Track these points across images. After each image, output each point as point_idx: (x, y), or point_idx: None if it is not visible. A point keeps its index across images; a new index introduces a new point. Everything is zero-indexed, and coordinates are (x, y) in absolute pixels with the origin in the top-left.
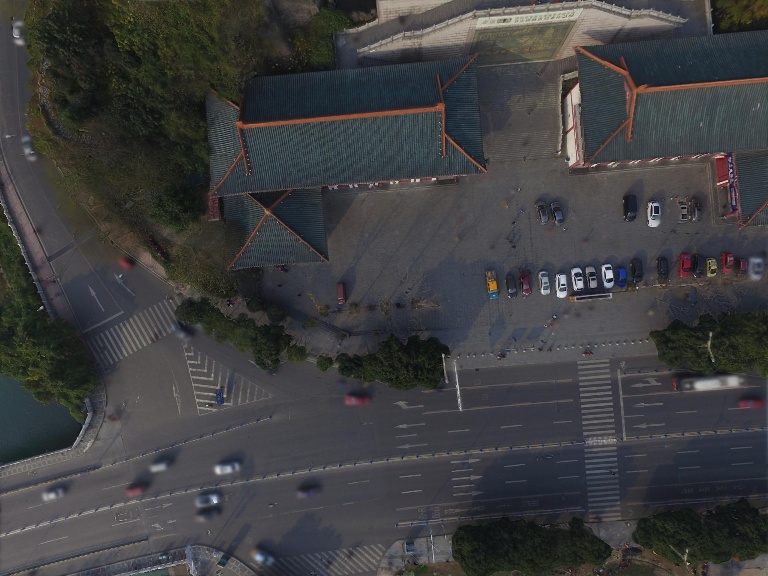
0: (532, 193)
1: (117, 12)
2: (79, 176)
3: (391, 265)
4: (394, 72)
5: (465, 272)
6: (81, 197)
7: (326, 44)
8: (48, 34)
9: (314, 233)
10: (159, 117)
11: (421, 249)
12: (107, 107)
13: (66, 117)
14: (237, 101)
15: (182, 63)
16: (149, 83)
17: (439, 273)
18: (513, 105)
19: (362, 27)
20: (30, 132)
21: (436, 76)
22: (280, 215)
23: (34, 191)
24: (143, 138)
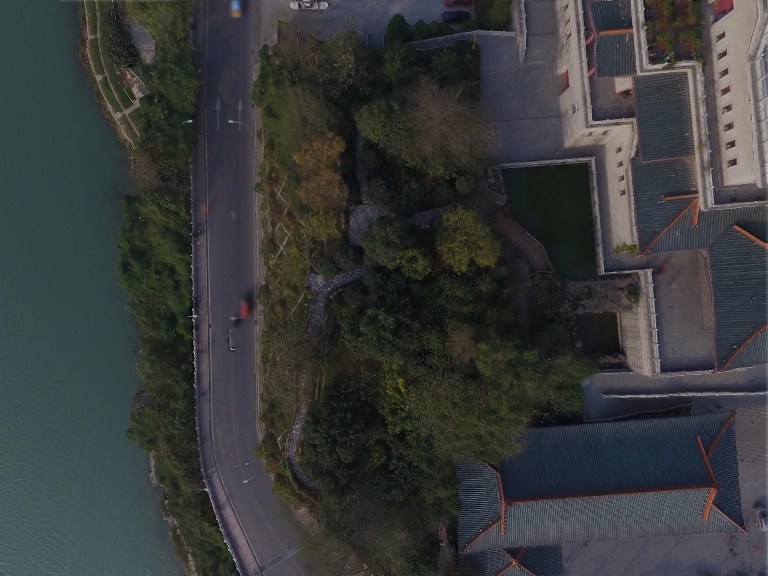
0: (750, 495)
1: (389, 398)
2: (341, 553)
3: (606, 567)
4: (650, 428)
5: (681, 575)
6: (338, 568)
7: (577, 395)
8: (331, 439)
9: (552, 570)
10: (415, 482)
11: (636, 551)
12: (368, 480)
13: (334, 502)
14: (494, 464)
15: (456, 450)
16: (414, 460)
17: (655, 575)
18: (737, 415)
19: (610, 373)
20: (266, 474)
21: (696, 436)
22: (524, 560)
23: (247, 502)
24: (399, 503)
